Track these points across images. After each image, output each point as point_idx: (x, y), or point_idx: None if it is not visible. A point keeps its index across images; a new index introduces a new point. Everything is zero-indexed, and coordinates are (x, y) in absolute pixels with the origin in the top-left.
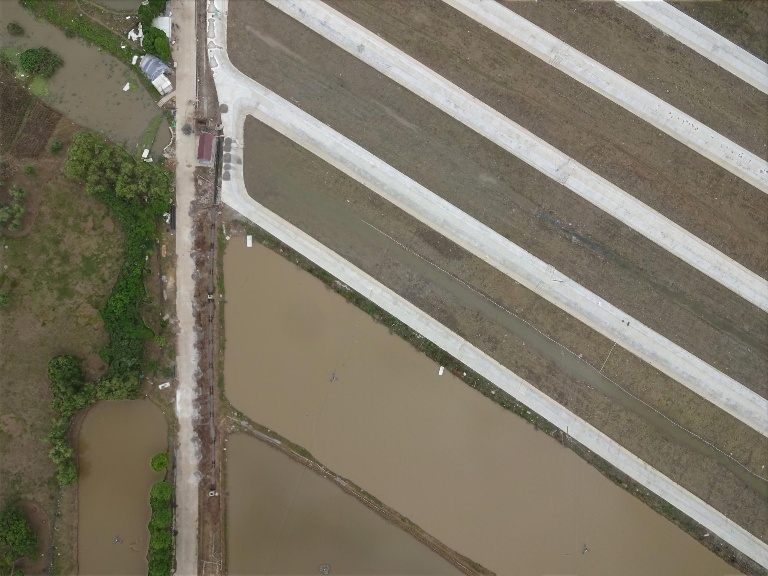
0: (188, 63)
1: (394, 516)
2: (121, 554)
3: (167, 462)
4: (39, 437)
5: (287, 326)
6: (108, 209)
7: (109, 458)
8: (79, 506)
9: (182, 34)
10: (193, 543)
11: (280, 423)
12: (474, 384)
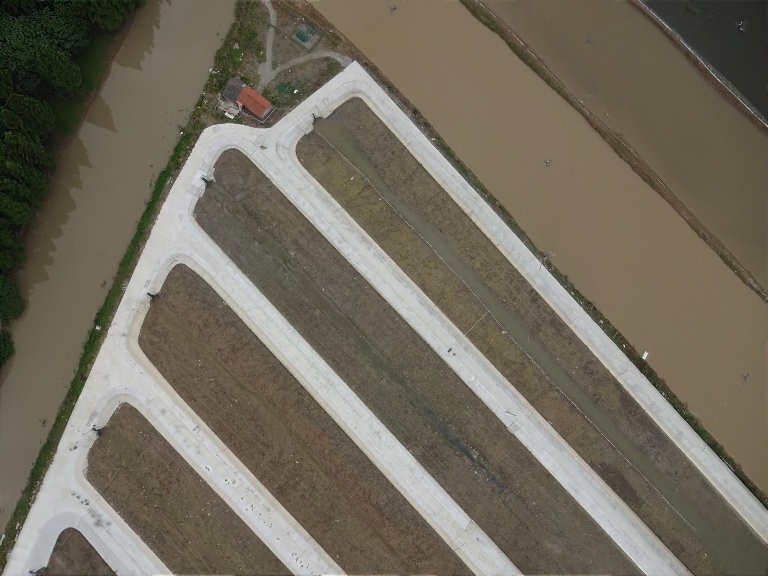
0: None
1: (712, 241)
2: None
3: None
4: None
5: None
6: None
7: None
8: None
9: None
10: None
11: None
12: (617, 334)
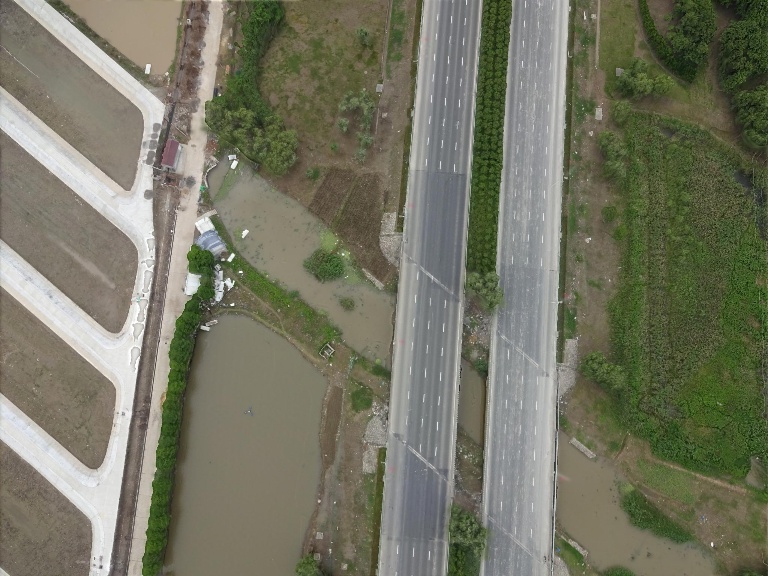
0: (180, 251)
1: None
2: None
3: None
4: None
5: None
6: None
7: None
8: None
9: (181, 284)
10: None
11: None
12: None
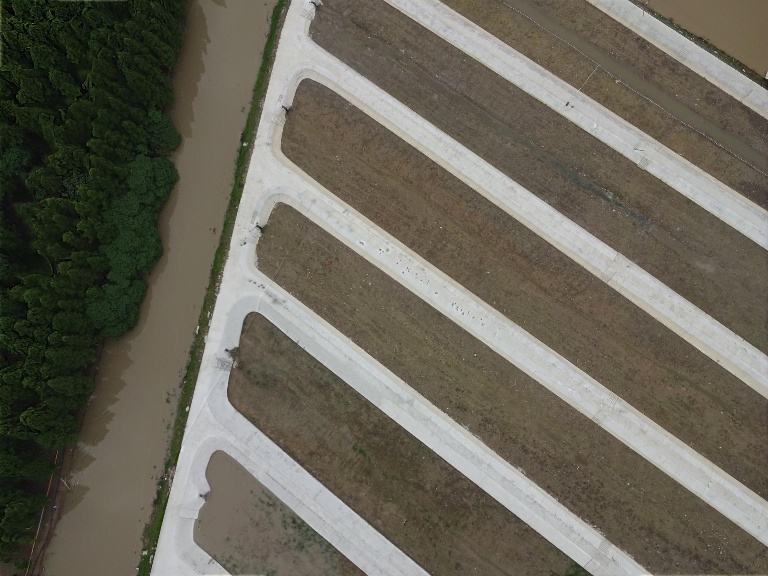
0: None
1: None
2: None
3: None
4: None
5: None
6: None
7: None
8: None
9: None
10: None
11: None
12: (734, 61)
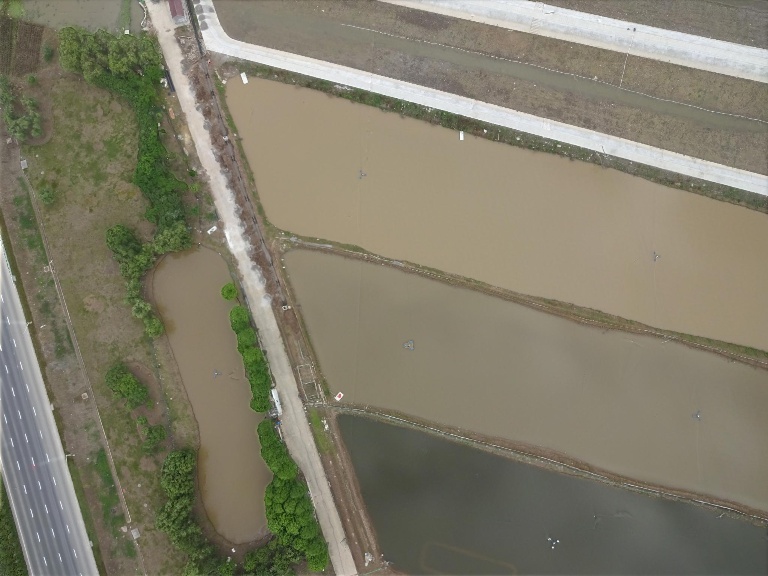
0: None
1: (458, 280)
2: (224, 385)
3: (235, 289)
4: (120, 307)
5: (304, 143)
6: (111, 94)
7: (187, 310)
8: (174, 355)
9: None
10: (283, 357)
11: (326, 230)
12: (497, 137)
